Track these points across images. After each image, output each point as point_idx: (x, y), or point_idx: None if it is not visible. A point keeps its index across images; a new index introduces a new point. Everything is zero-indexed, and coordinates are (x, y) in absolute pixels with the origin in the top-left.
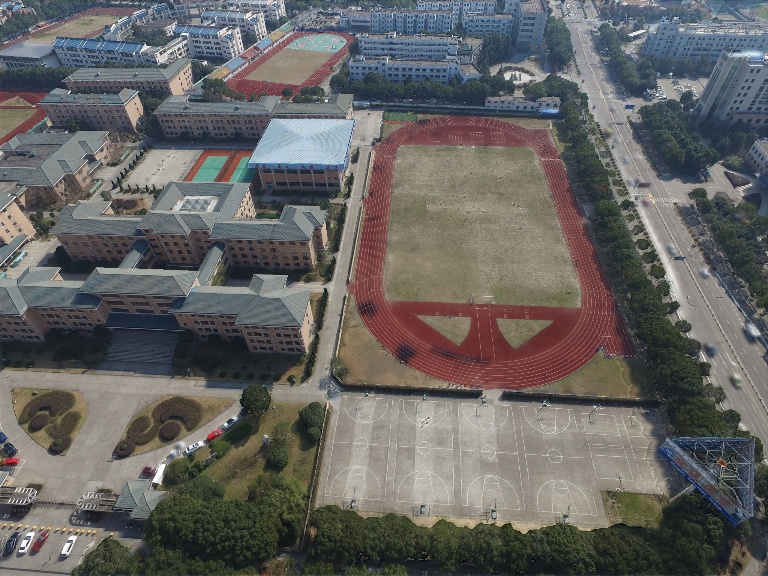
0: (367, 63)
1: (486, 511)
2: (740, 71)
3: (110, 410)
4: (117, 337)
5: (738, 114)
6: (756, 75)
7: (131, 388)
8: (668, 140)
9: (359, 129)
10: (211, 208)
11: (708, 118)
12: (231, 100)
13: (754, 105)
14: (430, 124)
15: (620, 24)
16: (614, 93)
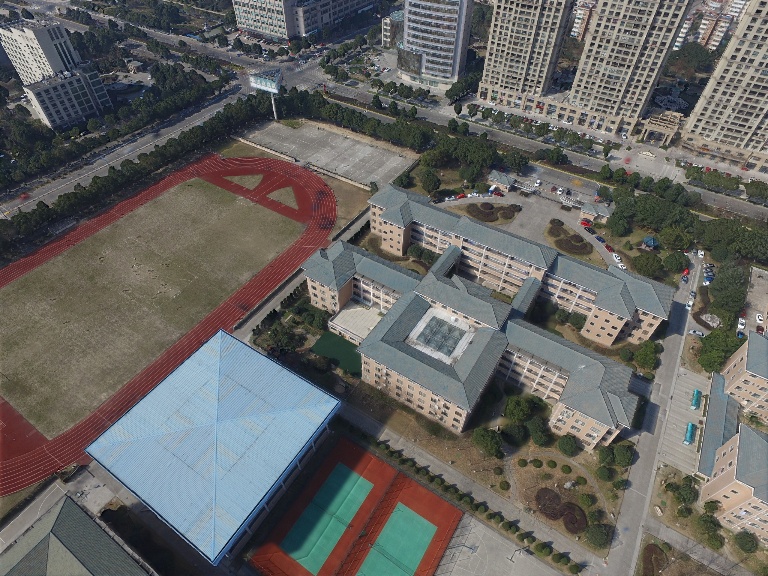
0: None
1: None
2: None
3: (528, 230)
4: None
5: None
6: None
7: None
8: None
9: None
10: (421, 325)
11: None
12: None
13: None
14: None
15: None
16: None
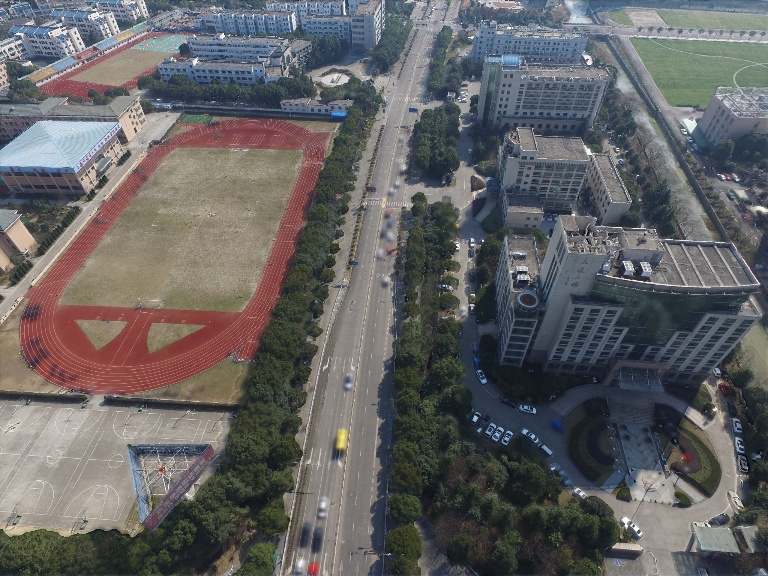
0: (175, 65)
1: (12, 516)
2: (499, 76)
3: None
4: None
5: (503, 118)
6: (511, 80)
7: None
8: (422, 144)
9: (147, 131)
10: None
11: (485, 122)
12: (37, 101)
13: (519, 109)
14: (219, 126)
15: (472, 26)
16: (420, 96)
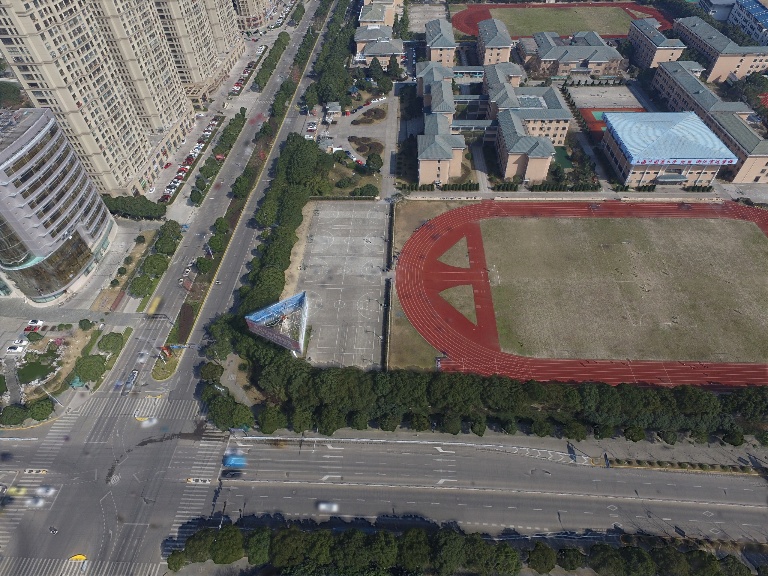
0: None
1: (306, 266)
2: None
3: (375, 130)
4: (421, 118)
5: None
6: None
7: (389, 133)
8: None
9: (766, 188)
10: None
11: None
12: None
13: None
14: None
15: None
16: None
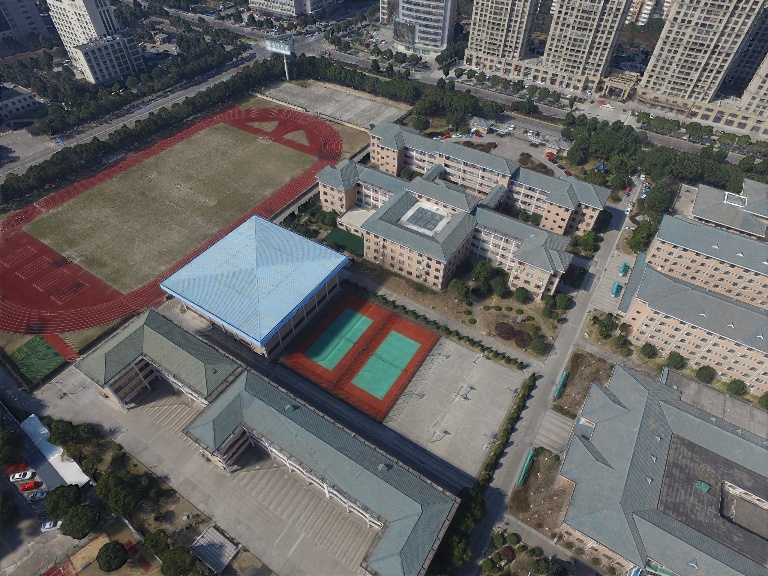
0: None
1: None
2: None
3: None
4: None
5: None
6: None
7: None
8: None
9: None
10: (410, 212)
11: None
12: None
13: None
14: (35, 319)
15: None
16: None
